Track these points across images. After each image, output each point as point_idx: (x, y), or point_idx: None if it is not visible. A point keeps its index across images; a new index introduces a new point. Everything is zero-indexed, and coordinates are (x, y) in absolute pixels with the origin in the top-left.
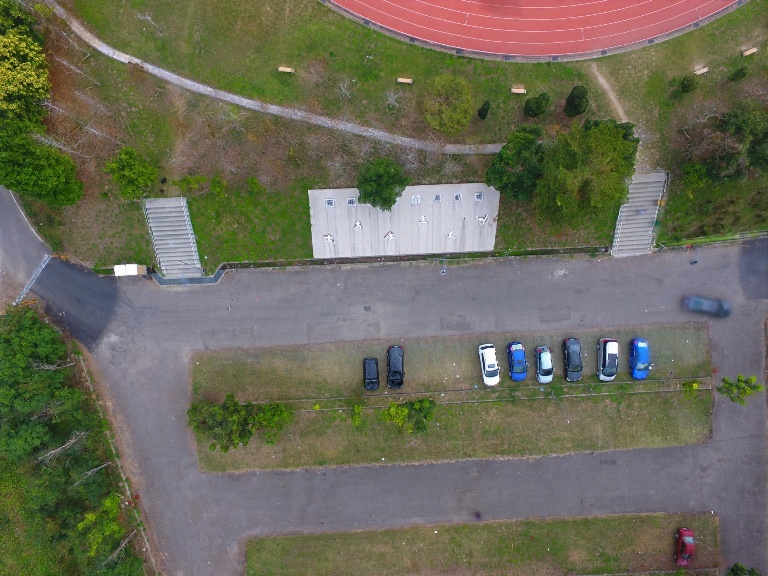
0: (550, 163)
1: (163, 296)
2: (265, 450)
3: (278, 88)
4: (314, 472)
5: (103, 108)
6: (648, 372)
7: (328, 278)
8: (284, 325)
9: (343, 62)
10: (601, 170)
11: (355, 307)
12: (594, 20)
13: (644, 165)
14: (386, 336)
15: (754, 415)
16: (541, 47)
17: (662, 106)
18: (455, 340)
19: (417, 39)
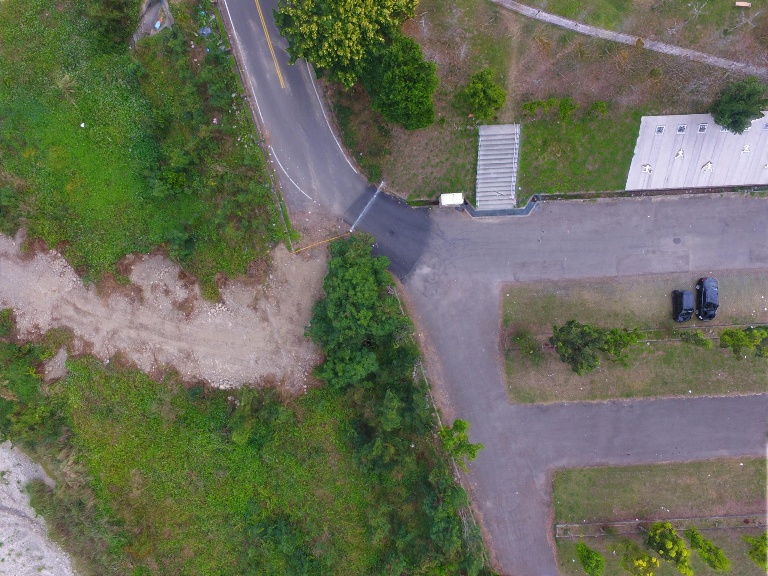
0: None
1: (475, 228)
2: (573, 382)
3: (613, 13)
4: (621, 404)
5: (437, 34)
6: None
7: (638, 210)
8: (594, 257)
9: None
10: None
11: (665, 239)
12: None
13: None
14: (695, 268)
15: None
16: None
17: None
18: (764, 273)
19: None
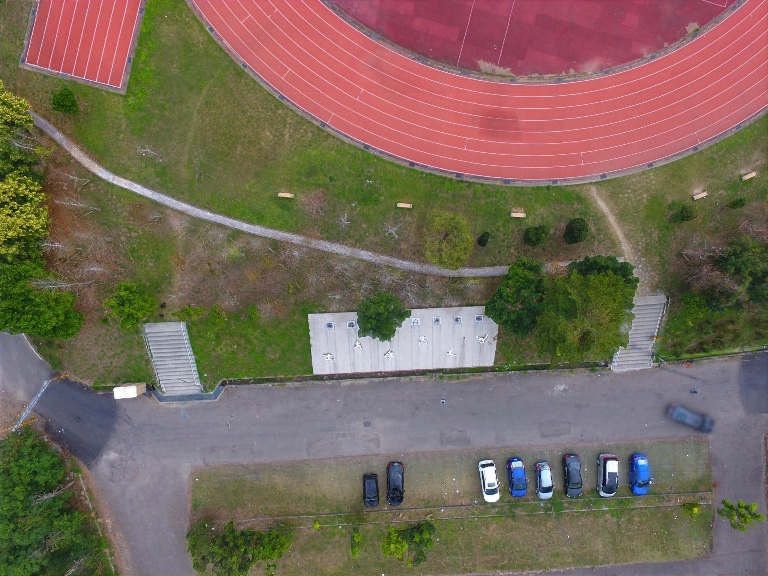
0: (550, 307)
1: (162, 413)
2: (265, 566)
3: (278, 213)
4: None
5: (103, 233)
6: (648, 487)
7: (328, 394)
8: (284, 441)
9: (343, 187)
10: (601, 321)
11: (355, 423)
12: (593, 144)
13: (644, 288)
14: (386, 451)
15: (754, 529)
16: (540, 171)
17: (661, 229)
18: (455, 455)
19: (417, 164)
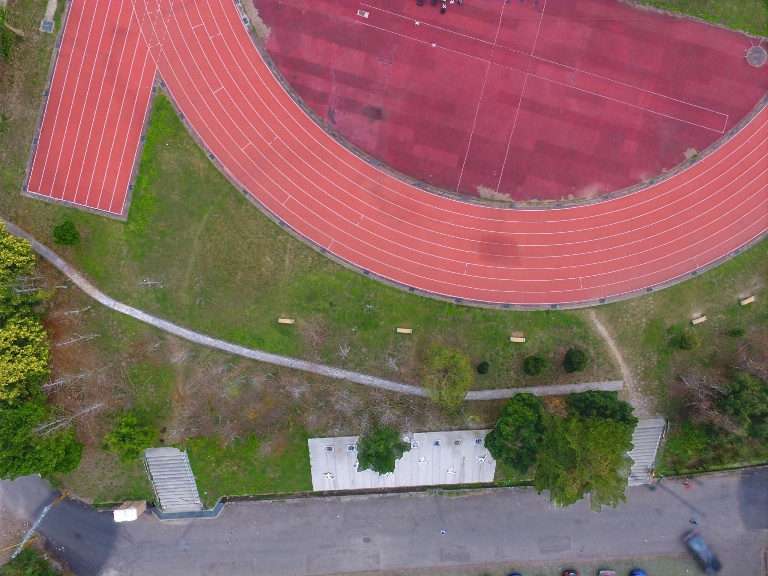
0: (549, 451)
1: (163, 530)
2: None
3: (278, 338)
4: None
5: (103, 358)
6: None
7: (328, 510)
8: (284, 558)
9: (343, 312)
10: (600, 473)
11: (355, 539)
12: (592, 269)
13: (643, 411)
14: (386, 567)
15: None
16: (540, 296)
17: (660, 353)
18: (455, 571)
19: (416, 289)
